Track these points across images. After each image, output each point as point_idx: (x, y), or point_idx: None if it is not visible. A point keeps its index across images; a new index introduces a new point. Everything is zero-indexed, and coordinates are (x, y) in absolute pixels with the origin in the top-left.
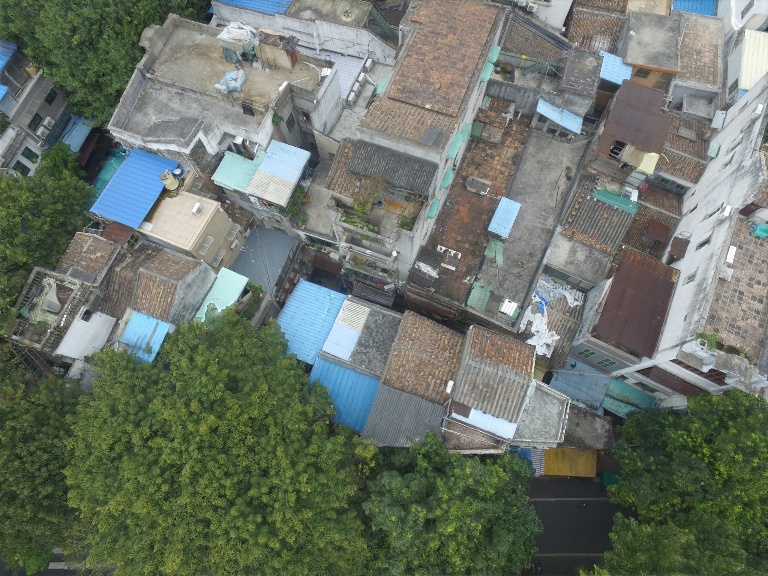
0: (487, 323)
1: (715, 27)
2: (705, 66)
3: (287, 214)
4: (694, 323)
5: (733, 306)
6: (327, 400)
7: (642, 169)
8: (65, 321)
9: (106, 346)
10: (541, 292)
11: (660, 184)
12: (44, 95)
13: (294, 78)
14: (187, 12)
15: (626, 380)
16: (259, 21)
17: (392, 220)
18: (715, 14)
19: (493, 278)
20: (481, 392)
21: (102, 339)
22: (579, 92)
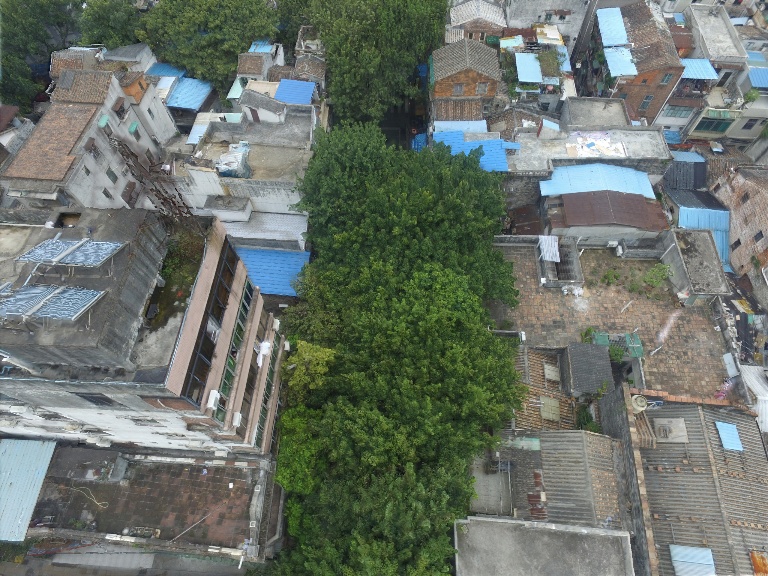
0: None
1: None
2: None
3: None
4: None
5: None
6: None
7: None
8: (300, 40)
9: None
10: None
11: None
12: None
13: None
14: None
15: None
16: None
17: None
18: None
19: None
20: None
21: None
22: None
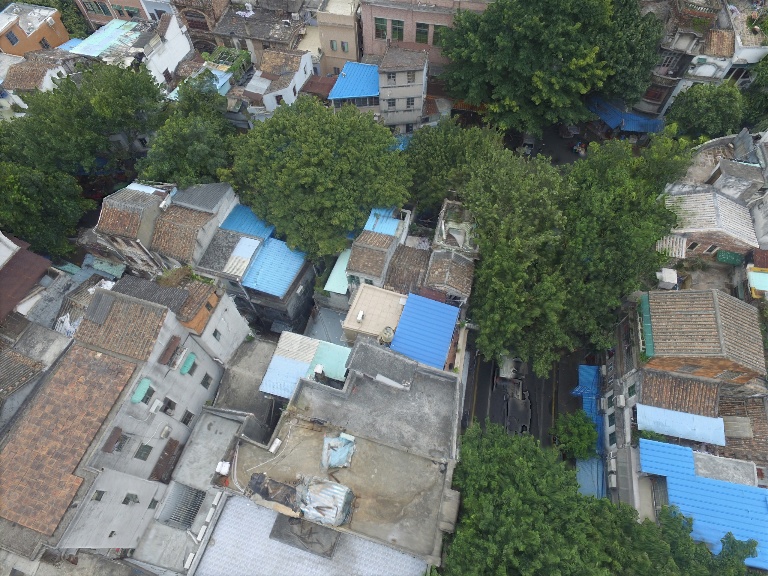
0: None
1: None
2: None
3: None
4: None
5: None
6: None
7: None
8: None
9: None
10: None
11: None
12: None
13: (266, 469)
14: None
15: None
16: None
17: None
18: None
19: None
20: None
21: None
22: None
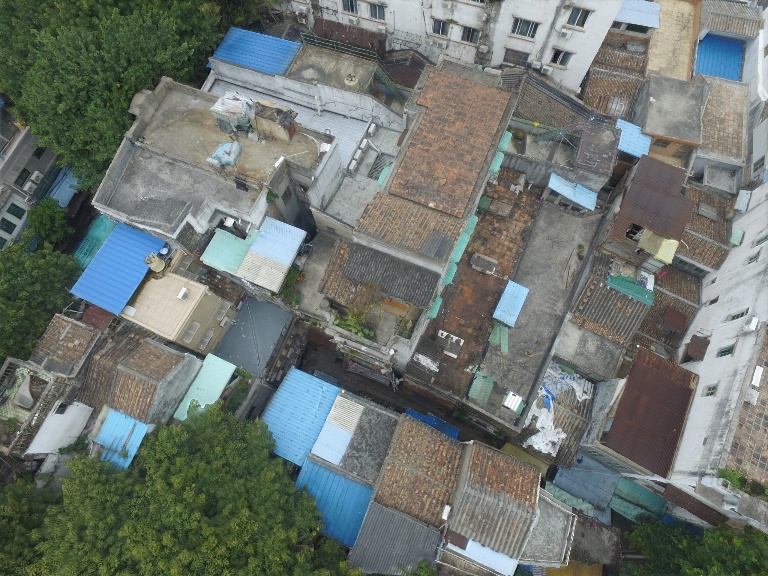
0: (489, 418)
1: (740, 93)
2: (729, 137)
3: (280, 295)
4: (715, 453)
5: (758, 433)
6: (314, 514)
7: (660, 257)
8: (37, 419)
9: (83, 433)
10: (548, 384)
11: (678, 265)
12: (32, 150)
13: (291, 151)
14: (182, 72)
15: (636, 480)
16: (258, 80)
17: (390, 322)
18: (740, 77)
19: (497, 367)
20: (480, 523)
21: (79, 427)
22: (594, 170)
